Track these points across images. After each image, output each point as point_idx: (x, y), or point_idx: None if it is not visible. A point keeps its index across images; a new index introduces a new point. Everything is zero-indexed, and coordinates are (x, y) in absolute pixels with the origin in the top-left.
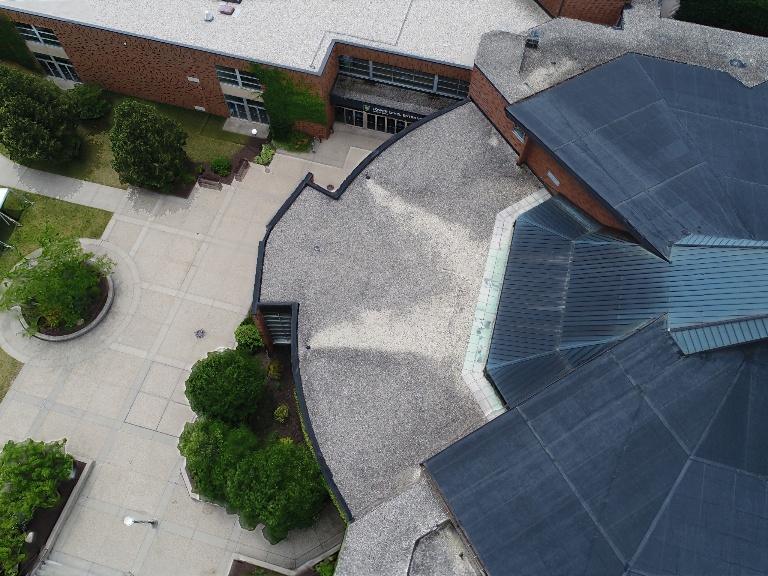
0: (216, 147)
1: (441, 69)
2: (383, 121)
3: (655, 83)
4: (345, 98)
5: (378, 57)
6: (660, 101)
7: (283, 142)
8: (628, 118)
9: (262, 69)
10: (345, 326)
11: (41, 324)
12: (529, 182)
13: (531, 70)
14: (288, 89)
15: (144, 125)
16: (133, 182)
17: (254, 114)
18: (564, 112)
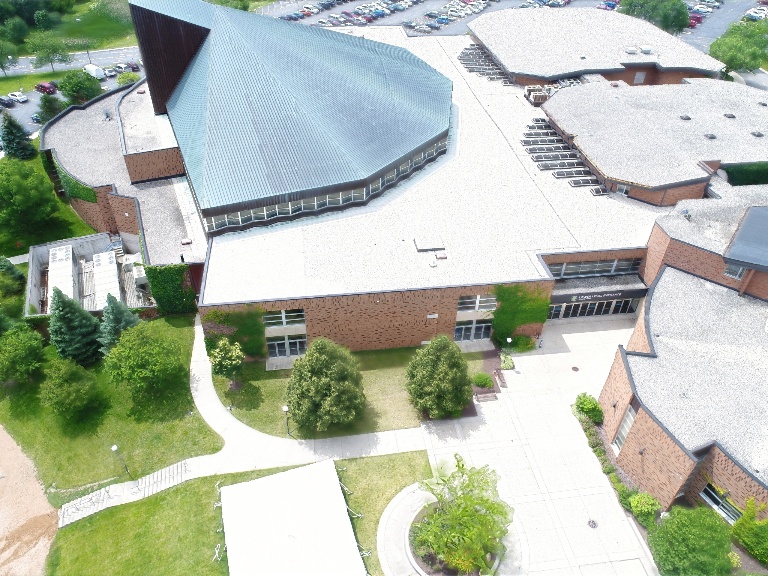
0: None
1: (622, 254)
2: (578, 307)
3: None
4: (558, 295)
5: (573, 258)
6: None
7: (514, 347)
8: None
9: (504, 288)
10: (763, 444)
11: (455, 575)
12: (759, 304)
13: (702, 233)
14: (522, 299)
15: (457, 354)
16: (440, 413)
17: (477, 332)
18: (763, 248)
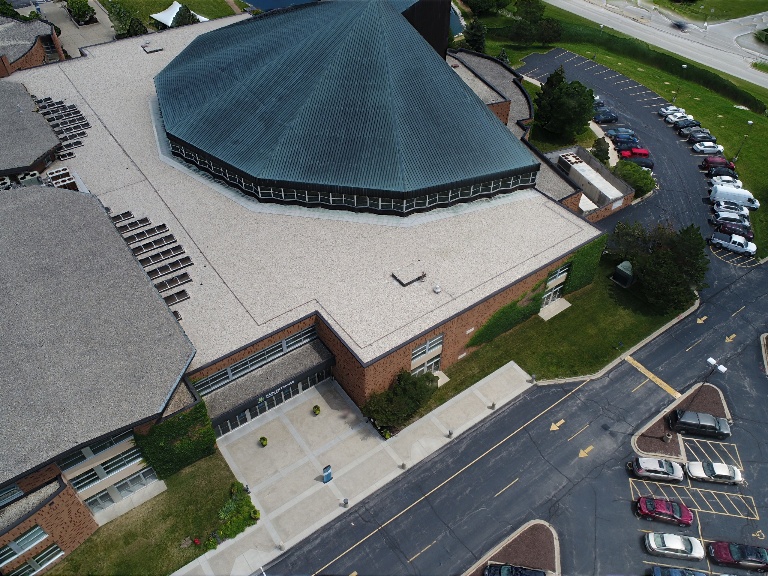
0: None
1: None
2: None
3: None
4: None
5: None
6: None
7: None
8: None
9: None
10: (6, 26)
11: None
12: None
13: None
14: None
15: None
16: None
17: None
18: None
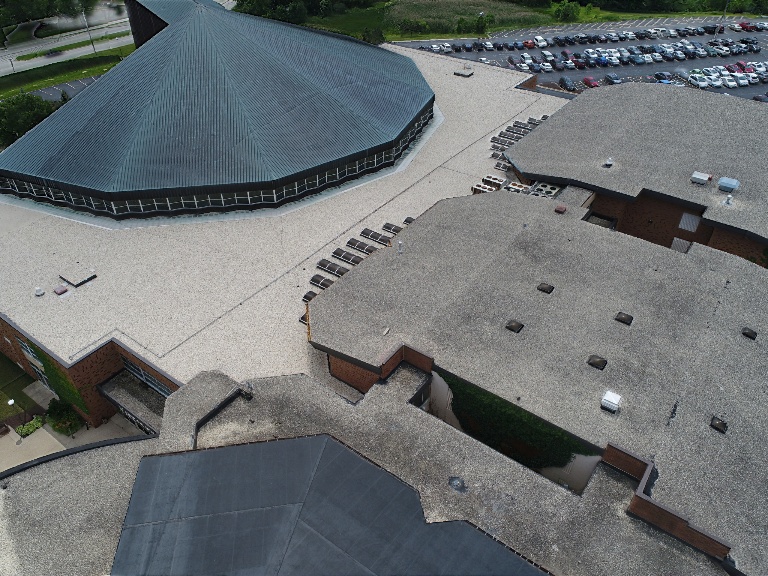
0: (2, 405)
1: None
2: None
3: (314, 480)
4: (105, 394)
5: (141, 364)
6: (295, 505)
7: (53, 418)
8: (240, 515)
9: (35, 348)
10: None
11: None
12: None
13: (223, 422)
14: (54, 371)
15: None
16: None
17: None
18: (187, 483)
